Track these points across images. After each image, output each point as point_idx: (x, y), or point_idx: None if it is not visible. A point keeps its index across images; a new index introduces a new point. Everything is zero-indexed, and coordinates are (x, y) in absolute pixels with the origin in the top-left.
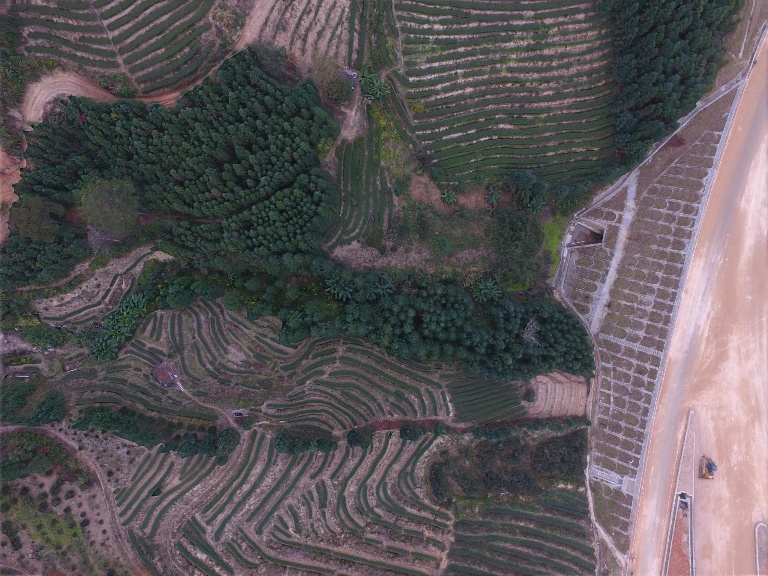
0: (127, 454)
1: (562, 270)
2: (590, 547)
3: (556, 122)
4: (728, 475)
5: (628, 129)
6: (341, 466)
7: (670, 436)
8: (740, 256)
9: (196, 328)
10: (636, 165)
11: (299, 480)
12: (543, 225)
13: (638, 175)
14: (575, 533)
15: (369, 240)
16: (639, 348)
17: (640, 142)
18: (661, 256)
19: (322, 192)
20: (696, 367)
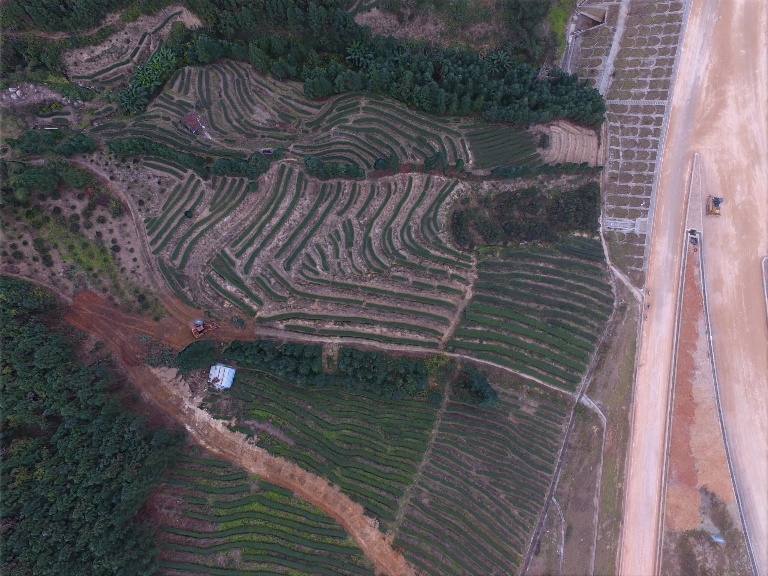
0: (158, 184)
1: (568, 54)
2: (607, 284)
3: None
4: (733, 214)
5: None
6: (367, 204)
7: (678, 177)
8: (732, 14)
9: (222, 87)
10: None
11: (326, 217)
12: None
13: None
14: (593, 272)
15: (388, 3)
16: (644, 103)
17: None
18: (660, 20)
19: None
20: (698, 114)
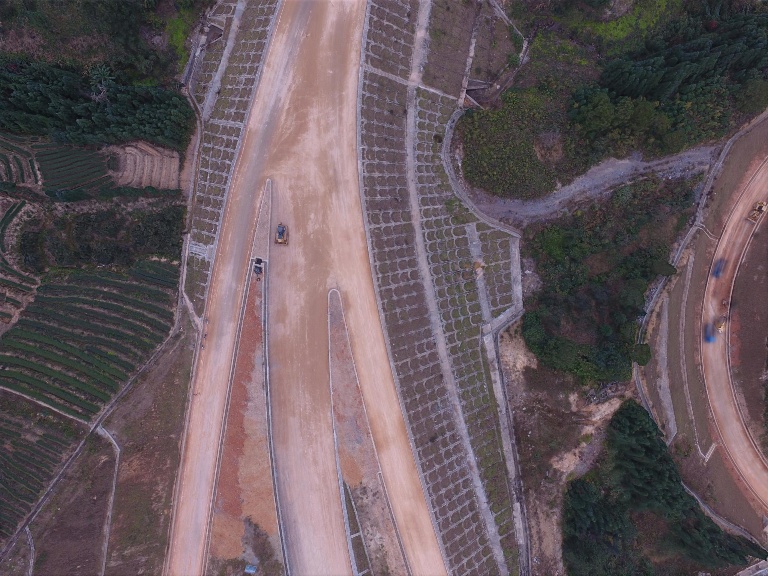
0: None
1: (193, 68)
2: (169, 311)
3: None
4: (304, 243)
5: None
6: None
7: (248, 204)
8: (322, 32)
9: None
10: None
11: None
12: (168, 20)
13: None
14: (157, 299)
15: None
16: (230, 124)
17: None
18: (254, 36)
19: None
20: (276, 138)
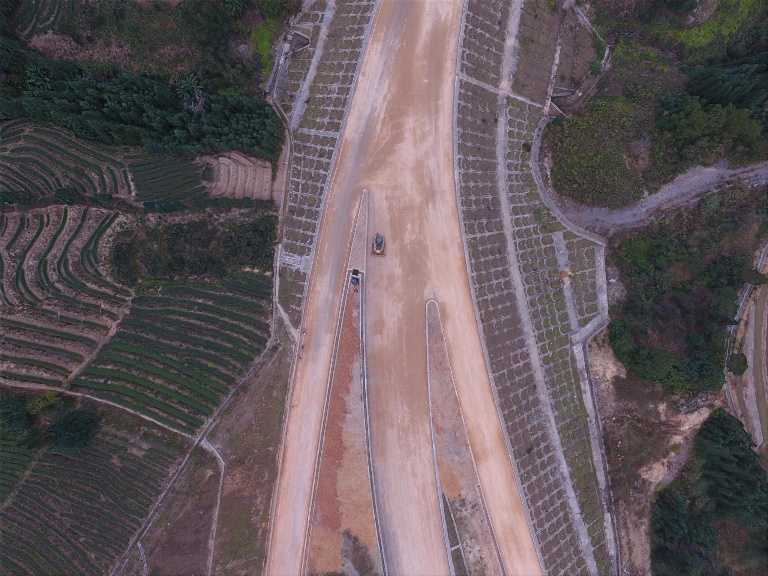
0: None
1: (277, 76)
2: (265, 323)
3: None
4: (401, 253)
5: None
6: (16, 237)
7: (344, 214)
8: (417, 41)
9: None
10: None
11: None
12: (253, 28)
13: None
14: (252, 310)
15: (59, 25)
16: (323, 134)
17: None
18: (347, 45)
19: None
20: (371, 148)
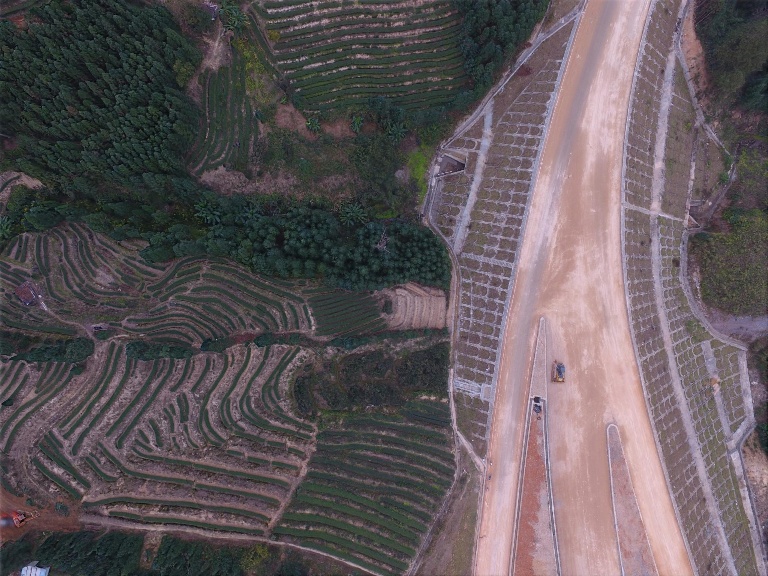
0: None
1: (430, 198)
2: (450, 453)
3: (409, 52)
4: (579, 379)
5: (472, 55)
6: (202, 378)
7: (523, 343)
8: (583, 173)
9: (63, 251)
10: (491, 95)
11: (159, 393)
12: (409, 154)
13: (493, 104)
14: (436, 441)
15: (233, 163)
16: (494, 262)
17: (481, 65)
18: (512, 176)
19: (177, 110)
20: (545, 277)
